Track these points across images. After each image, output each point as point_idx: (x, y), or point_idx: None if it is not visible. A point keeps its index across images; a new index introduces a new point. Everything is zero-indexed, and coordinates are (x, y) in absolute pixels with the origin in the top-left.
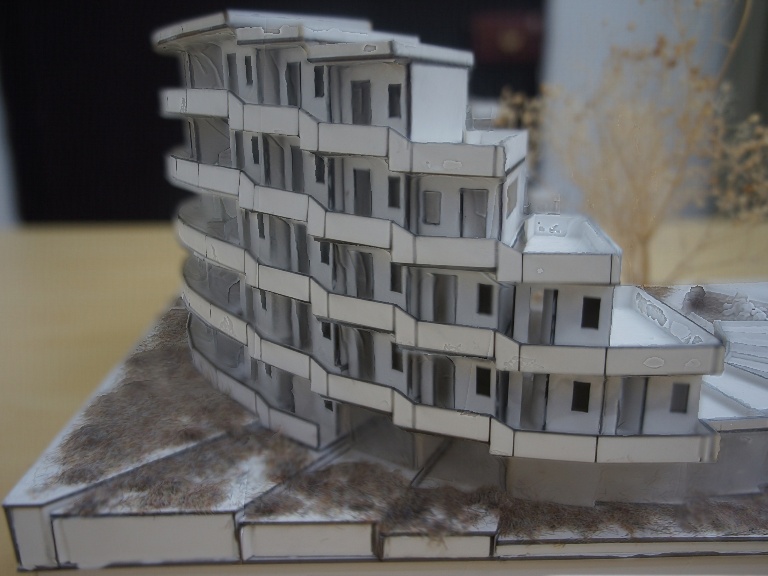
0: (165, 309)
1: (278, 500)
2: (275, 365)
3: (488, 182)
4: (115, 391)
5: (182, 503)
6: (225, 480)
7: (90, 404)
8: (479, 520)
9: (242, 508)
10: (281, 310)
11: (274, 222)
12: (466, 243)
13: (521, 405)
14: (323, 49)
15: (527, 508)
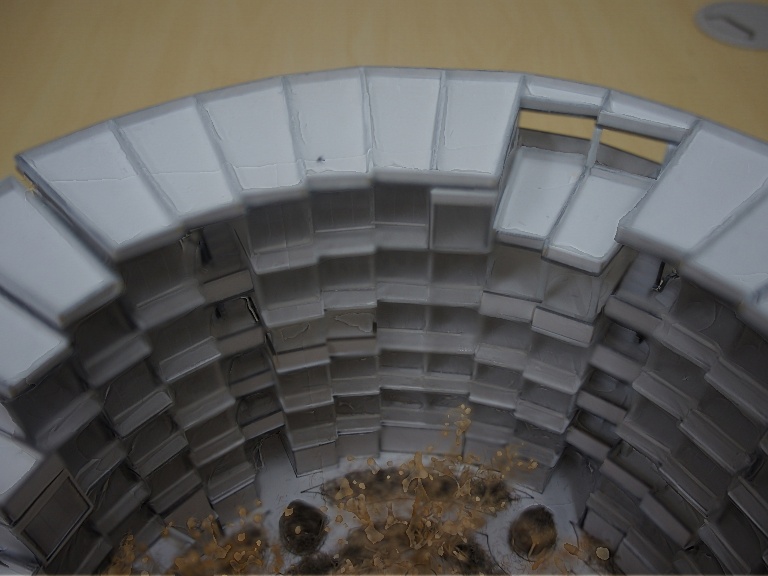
0: None
1: None
2: None
3: None
4: None
5: None
6: None
7: None
8: None
9: None
10: None
11: None
12: None
13: None
14: None
15: None
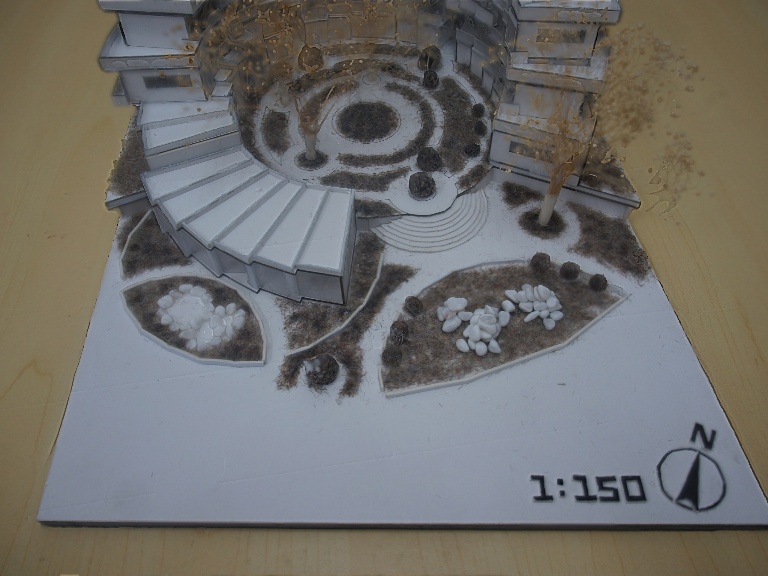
0: None
1: None
2: None
3: None
4: None
5: None
6: None
7: None
8: None
9: None
10: None
11: None
12: None
13: None
14: None
15: None
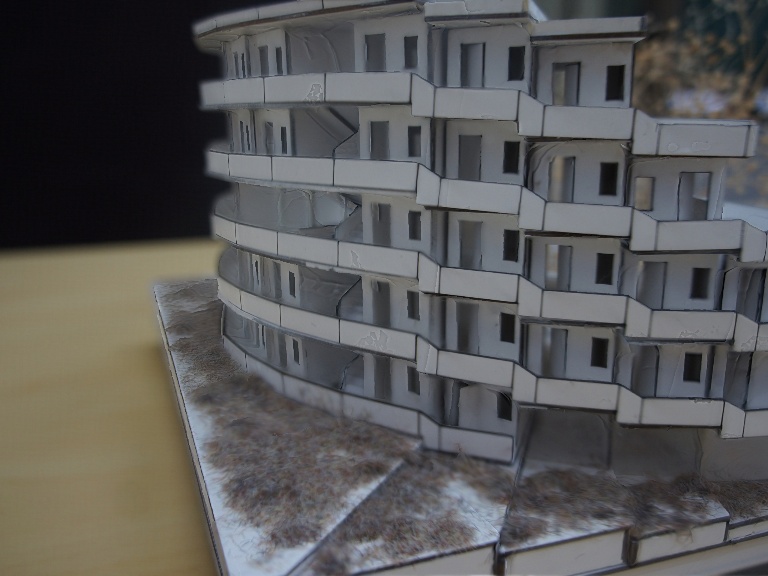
0: (168, 339)
1: (525, 522)
2: (458, 377)
3: (724, 163)
4: (219, 435)
5: (437, 544)
6: (450, 511)
7: (206, 453)
8: (706, 507)
9: (499, 537)
10: (436, 318)
11: (436, 220)
12: (714, 225)
13: (723, 387)
14: (555, 26)
15: (732, 489)
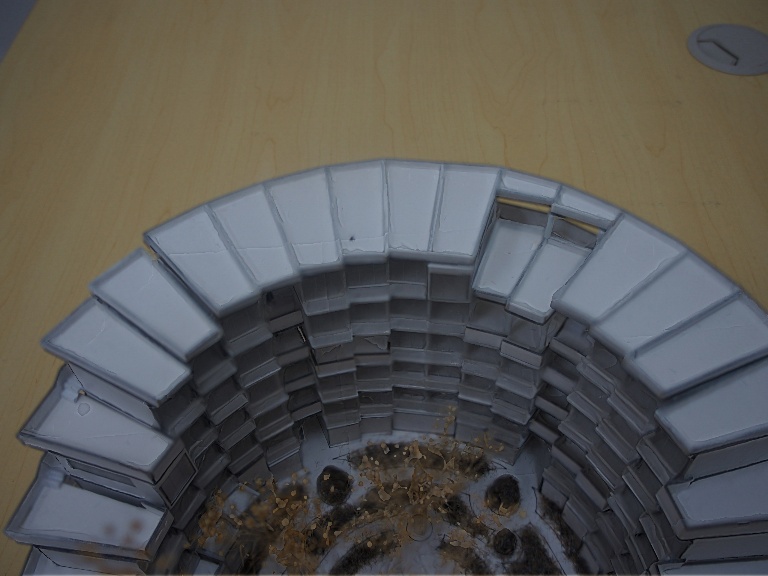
0: None
1: None
2: None
3: None
4: None
5: None
6: None
7: None
8: None
9: None
10: None
11: None
12: None
13: None
14: None
15: None
